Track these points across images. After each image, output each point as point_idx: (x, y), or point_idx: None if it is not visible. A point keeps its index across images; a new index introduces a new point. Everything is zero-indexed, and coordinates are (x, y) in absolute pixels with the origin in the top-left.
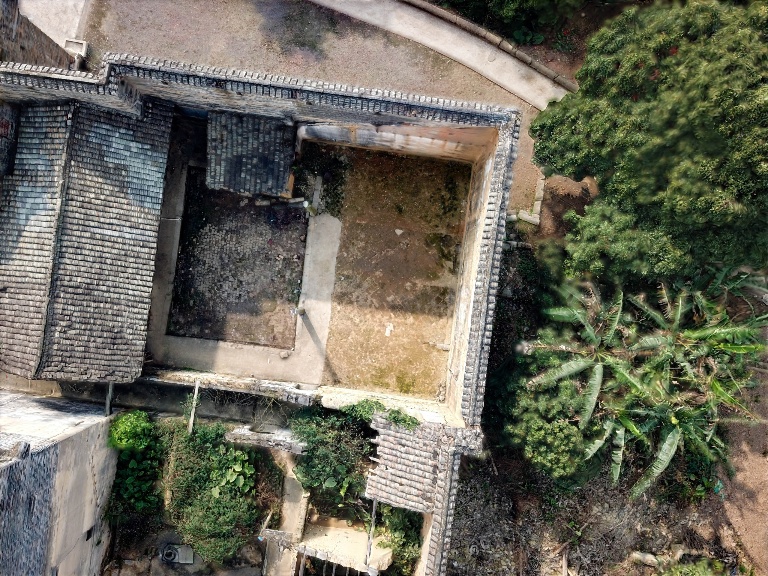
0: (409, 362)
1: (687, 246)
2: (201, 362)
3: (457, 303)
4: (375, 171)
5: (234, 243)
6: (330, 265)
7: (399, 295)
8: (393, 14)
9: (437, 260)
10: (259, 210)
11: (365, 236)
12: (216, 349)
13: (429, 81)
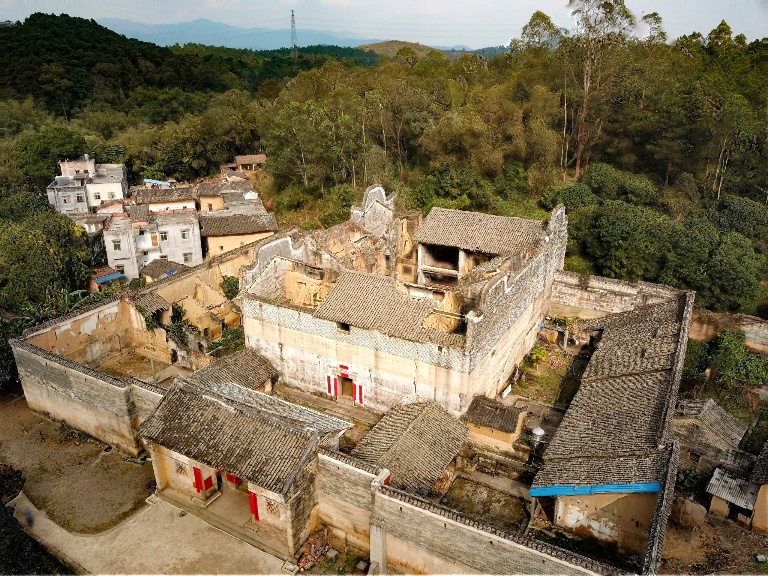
0: None
1: (8, 323)
2: None
3: None
4: None
5: None
6: None
7: None
8: None
9: None
10: None
11: None
12: None
13: None
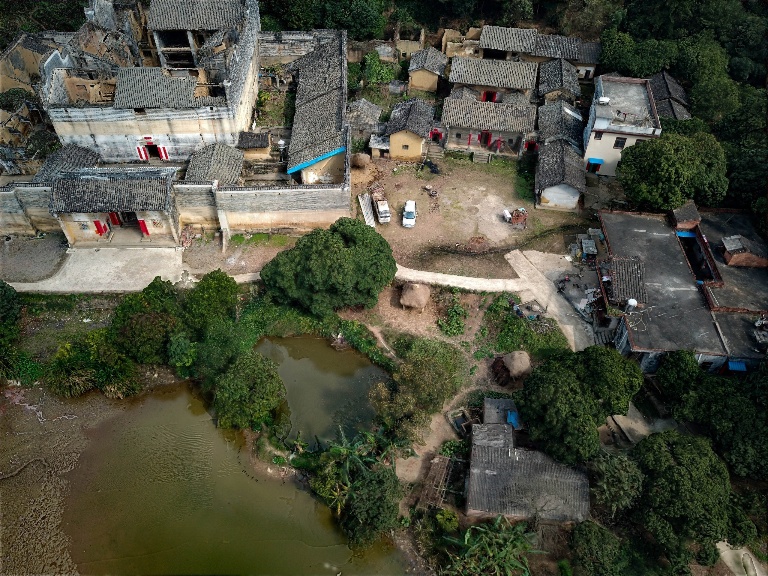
0: None
1: None
2: None
3: None
4: None
5: None
6: None
7: None
8: None
9: None
10: None
11: None
12: None
13: None
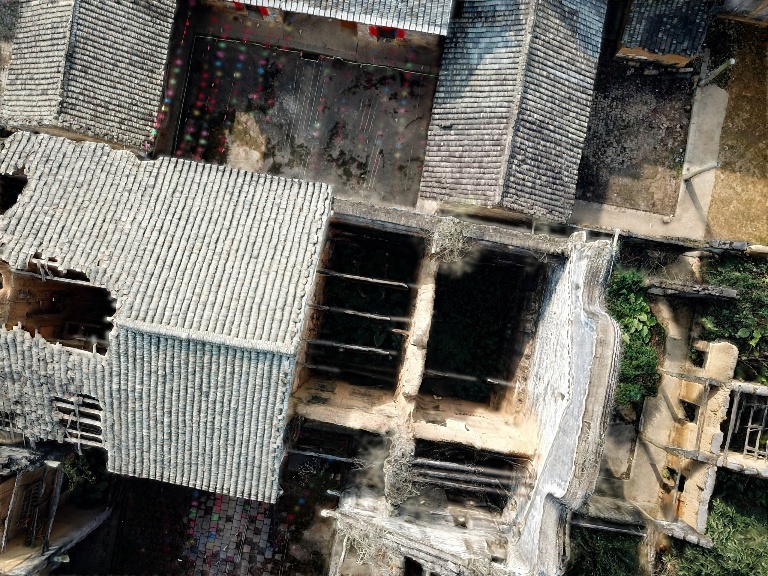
0: None
1: None
2: None
3: None
4: (763, 45)
5: (619, 110)
6: (715, 135)
7: None
8: None
9: None
10: (644, 80)
11: (750, 108)
12: (600, 211)
13: None
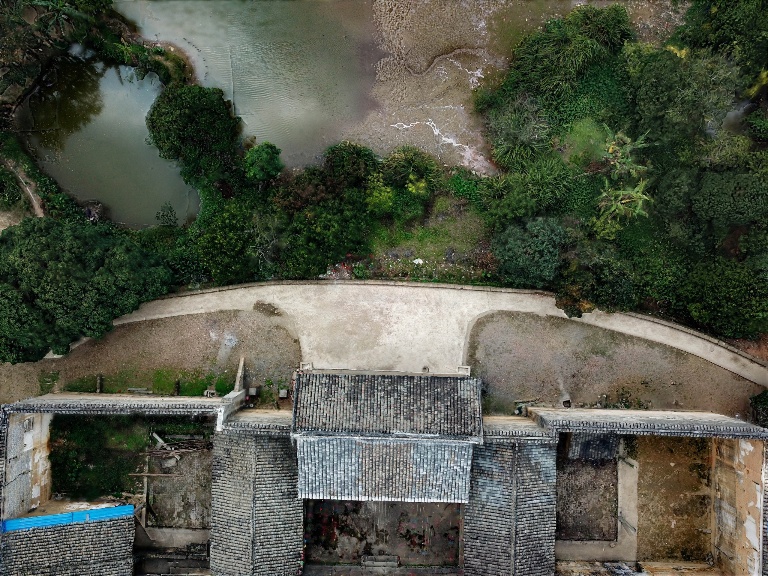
0: (687, 542)
1: None
2: (564, 555)
3: (716, 507)
4: None
5: (574, 480)
6: (634, 489)
7: (677, 502)
8: (650, 329)
9: (697, 479)
10: None
11: (653, 469)
12: (571, 546)
13: (675, 367)
